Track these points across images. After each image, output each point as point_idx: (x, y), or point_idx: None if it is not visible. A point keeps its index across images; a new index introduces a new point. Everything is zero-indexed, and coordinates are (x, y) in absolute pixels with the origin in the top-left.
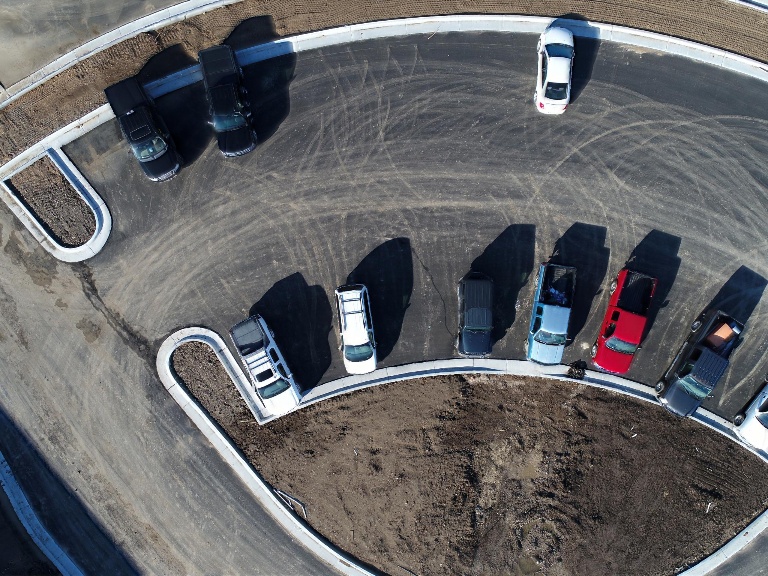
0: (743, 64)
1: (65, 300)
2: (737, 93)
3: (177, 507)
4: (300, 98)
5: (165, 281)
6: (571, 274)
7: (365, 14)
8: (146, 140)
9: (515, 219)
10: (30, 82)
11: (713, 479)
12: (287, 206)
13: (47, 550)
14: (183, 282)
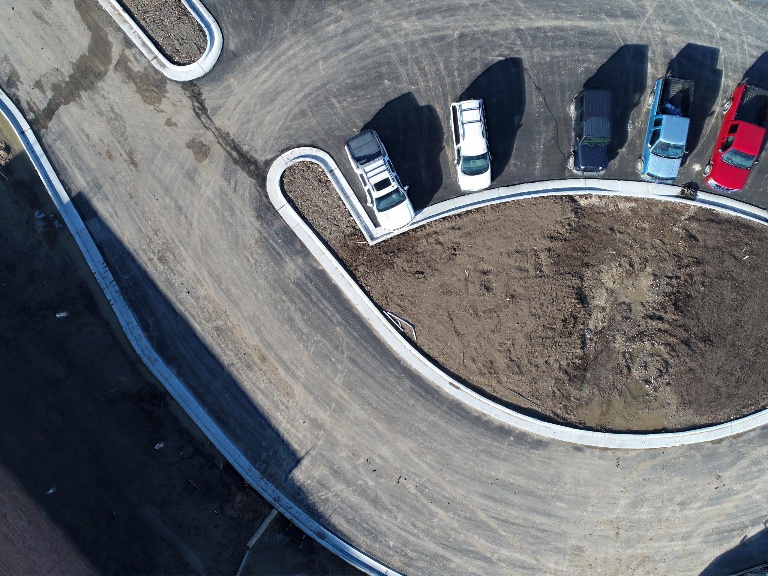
0: None
1: (175, 119)
2: None
3: (286, 329)
4: None
5: (276, 101)
6: (687, 90)
7: None
8: None
9: (628, 39)
10: None
11: None
12: (399, 25)
13: (156, 370)
14: (294, 102)
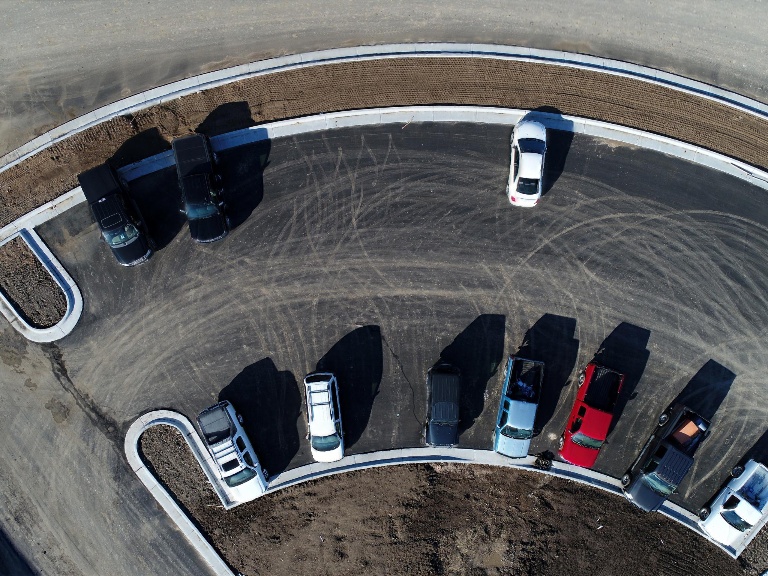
0: (715, 159)
1: (34, 380)
2: (708, 188)
3: None
4: (274, 184)
5: (135, 363)
6: (539, 367)
7: (340, 102)
8: (117, 228)
9: (485, 309)
10: (4, 162)
11: (678, 571)
12: (258, 291)
13: None
14: (153, 365)
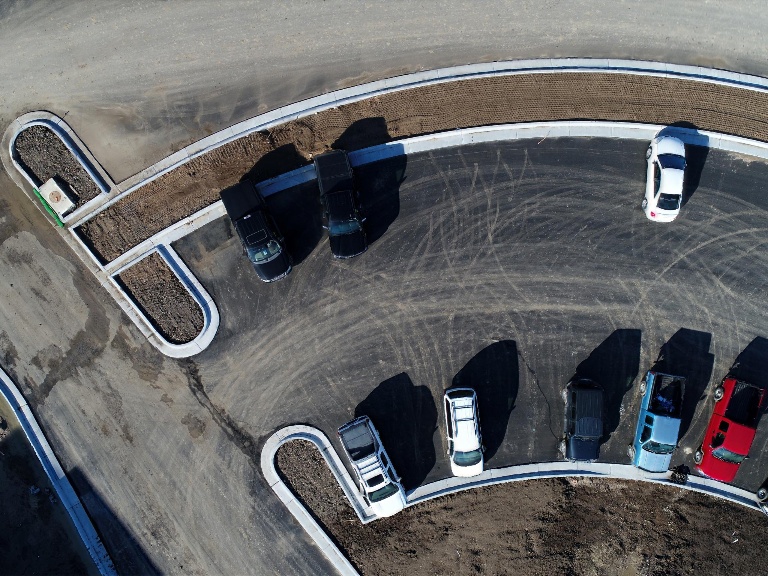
0: None
1: (171, 395)
2: None
3: None
4: (410, 199)
5: (271, 378)
6: (679, 382)
7: (476, 118)
8: (262, 244)
9: (621, 324)
10: (141, 178)
11: None
12: (395, 306)
13: None
14: (289, 380)
